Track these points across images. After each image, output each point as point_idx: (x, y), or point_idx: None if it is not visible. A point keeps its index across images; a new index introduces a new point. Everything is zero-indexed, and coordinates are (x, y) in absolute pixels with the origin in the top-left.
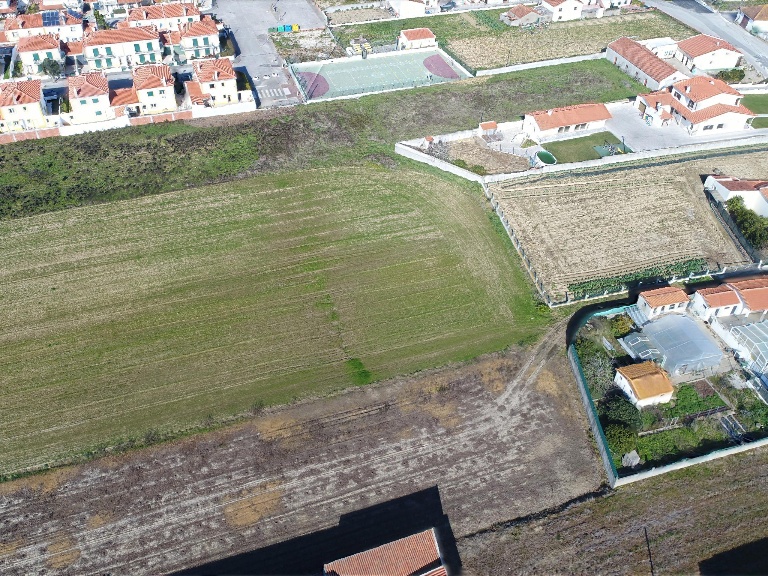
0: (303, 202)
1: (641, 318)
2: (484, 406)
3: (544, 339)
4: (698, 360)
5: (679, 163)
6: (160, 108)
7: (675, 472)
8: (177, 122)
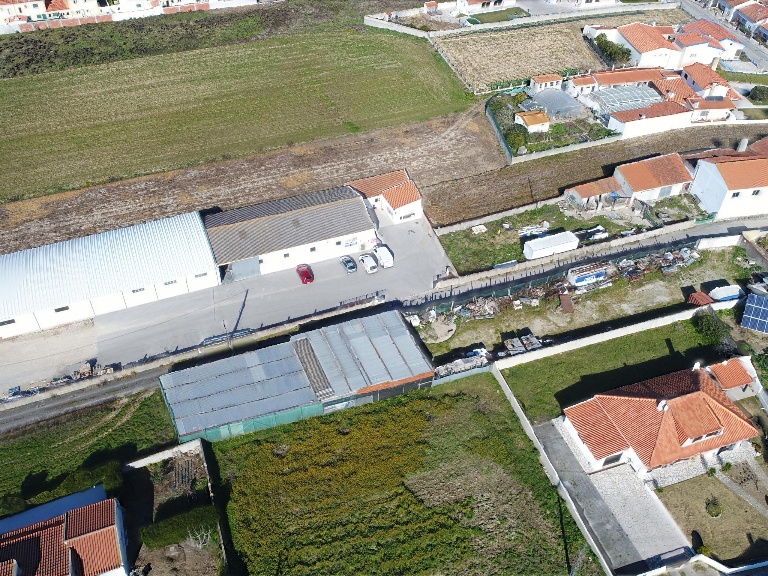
0: (302, 51)
1: (532, 92)
2: (433, 137)
3: (471, 109)
4: (566, 108)
5: (567, 23)
6: (184, 3)
7: (548, 157)
8: (199, 11)
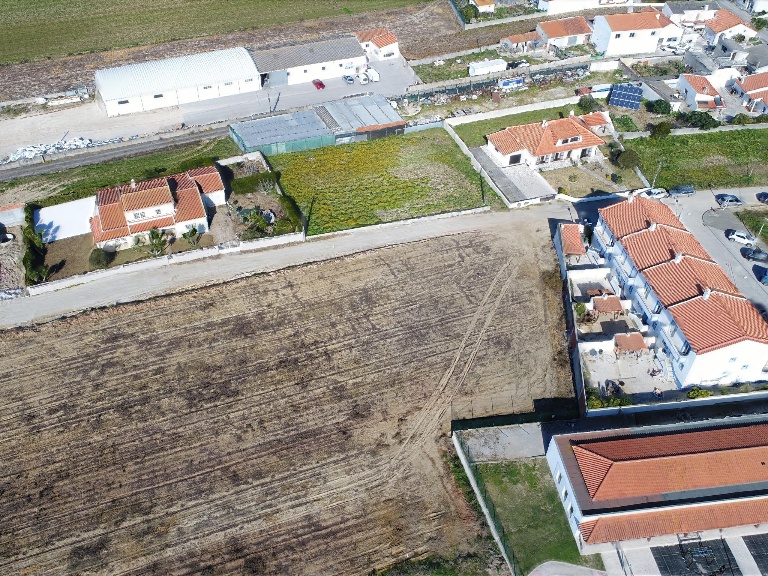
0: None
1: None
2: (408, 16)
3: (437, 1)
4: None
5: None
6: None
7: (492, 25)
8: None
